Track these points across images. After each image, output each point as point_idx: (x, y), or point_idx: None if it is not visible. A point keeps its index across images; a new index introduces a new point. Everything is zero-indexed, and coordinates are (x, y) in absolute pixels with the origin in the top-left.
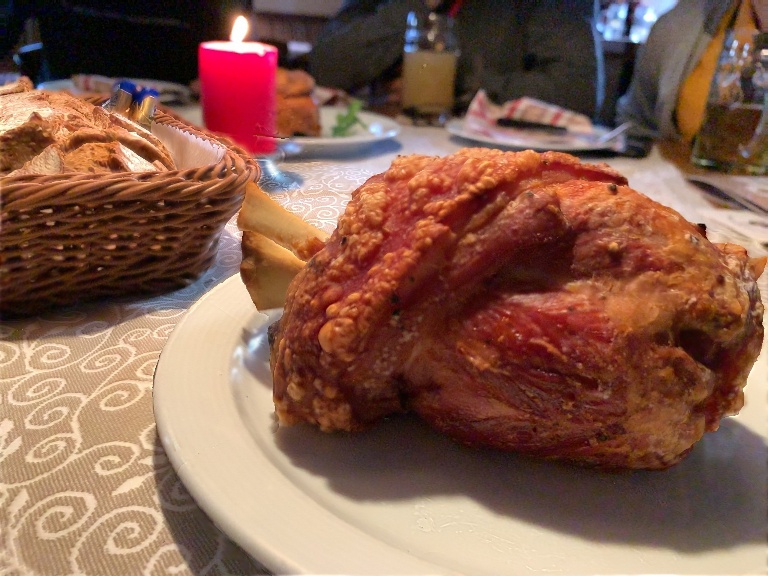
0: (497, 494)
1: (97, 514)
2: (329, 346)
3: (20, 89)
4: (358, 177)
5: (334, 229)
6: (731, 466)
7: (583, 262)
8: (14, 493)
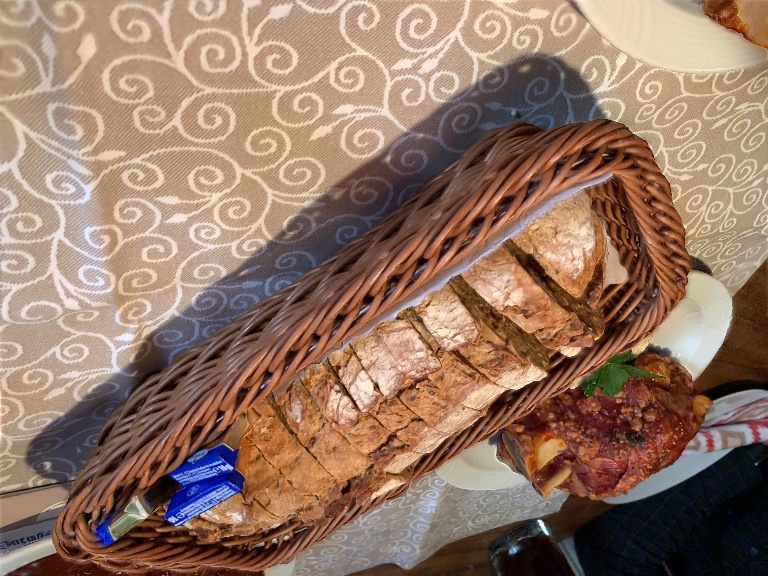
0: None
1: None
2: None
3: (388, 477)
4: None
5: (289, 18)
6: None
7: None
8: None
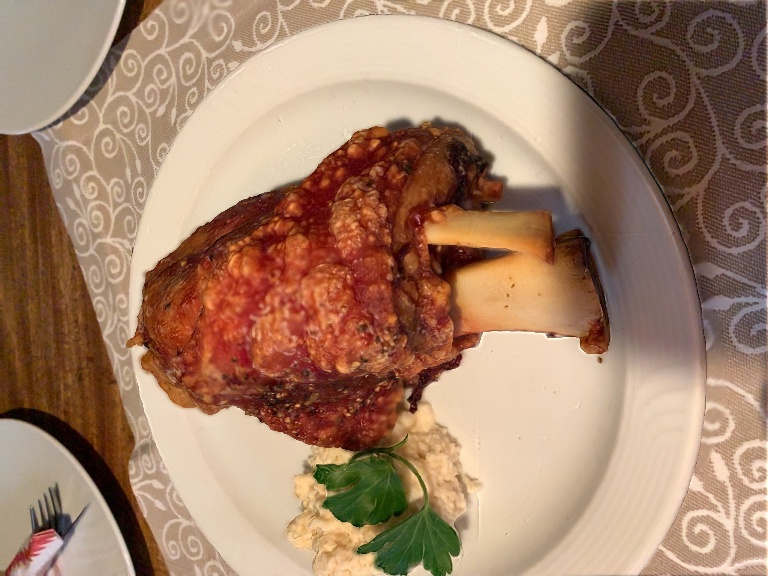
0: None
1: None
2: None
3: None
4: None
5: None
6: None
7: None
8: None
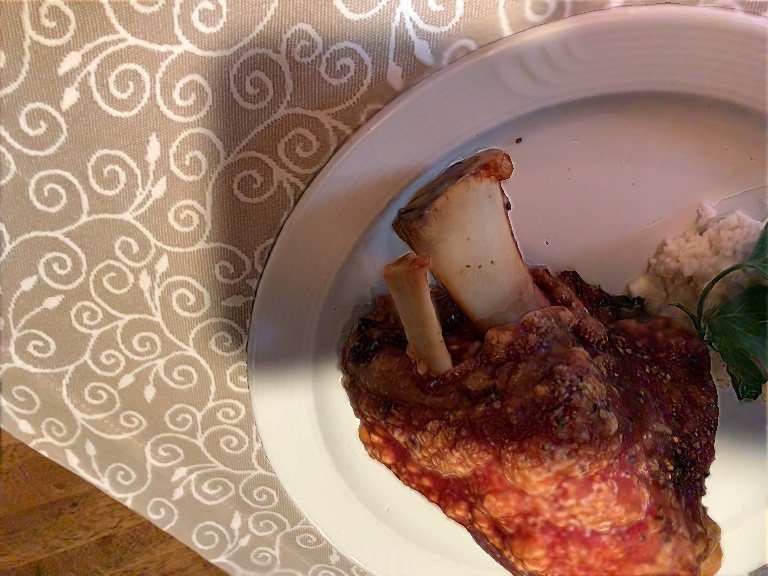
0: None
1: (209, 314)
2: None
3: None
4: None
5: None
6: None
7: None
8: (159, 253)
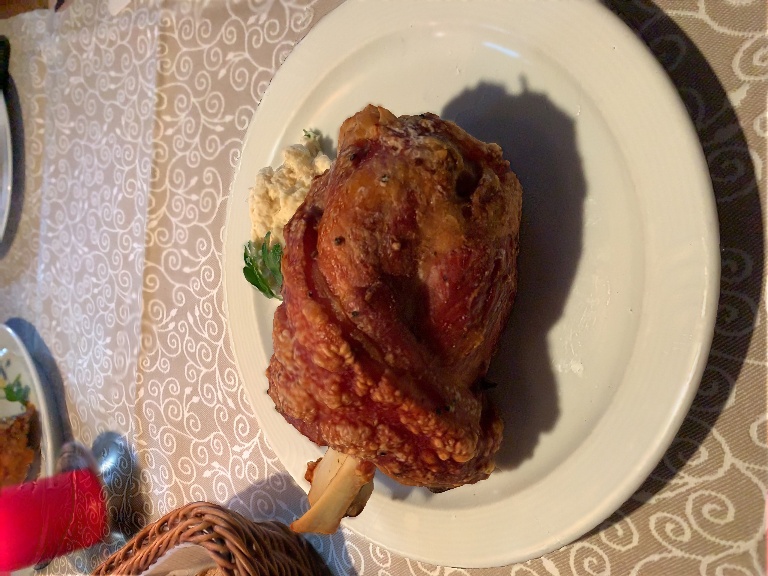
0: (545, 312)
1: None
2: (472, 455)
3: None
4: (97, 374)
5: (198, 404)
6: (500, 127)
7: (406, 268)
8: None
